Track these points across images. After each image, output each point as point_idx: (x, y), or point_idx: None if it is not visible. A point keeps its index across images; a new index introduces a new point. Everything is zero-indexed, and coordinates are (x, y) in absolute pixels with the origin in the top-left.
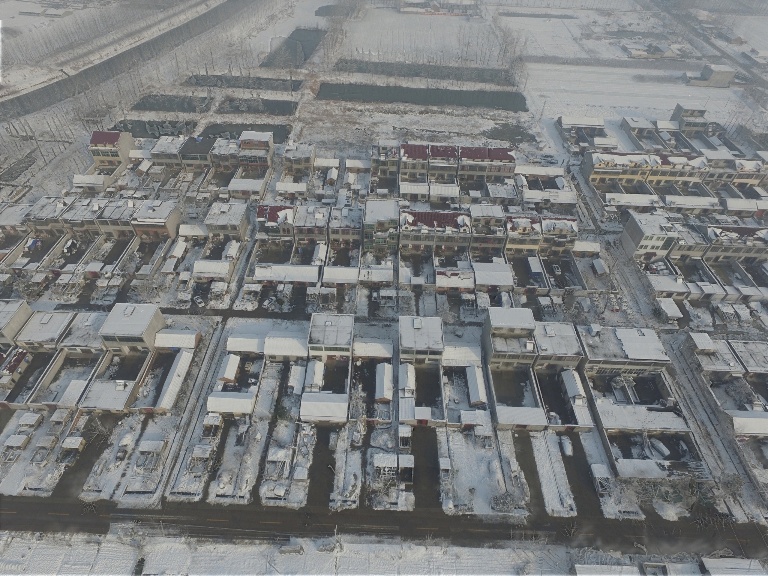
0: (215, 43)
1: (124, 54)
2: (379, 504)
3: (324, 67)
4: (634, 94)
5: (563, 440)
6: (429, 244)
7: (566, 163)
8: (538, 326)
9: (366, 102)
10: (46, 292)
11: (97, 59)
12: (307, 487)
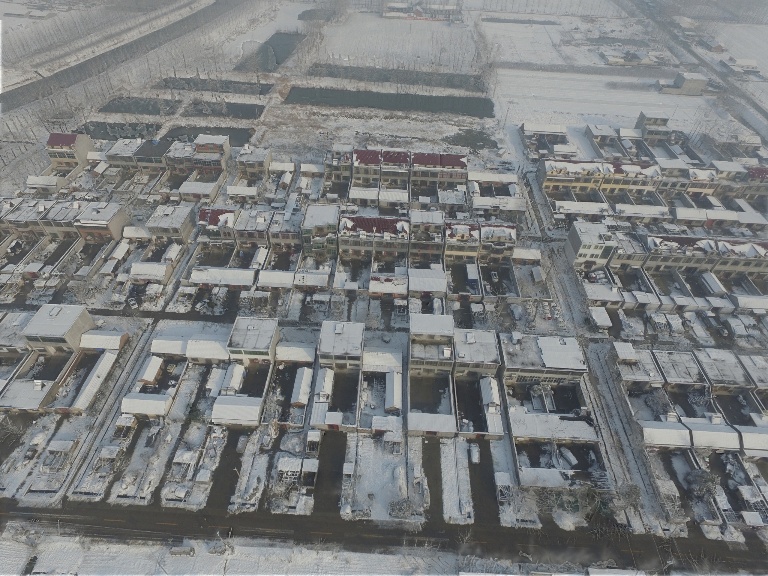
0: (192, 46)
1: (102, 56)
2: (278, 508)
3: (297, 71)
4: (604, 101)
5: (471, 447)
6: (368, 249)
7: (522, 170)
8: (460, 333)
9: (333, 106)
10: None
11: (73, 61)
12: (208, 489)
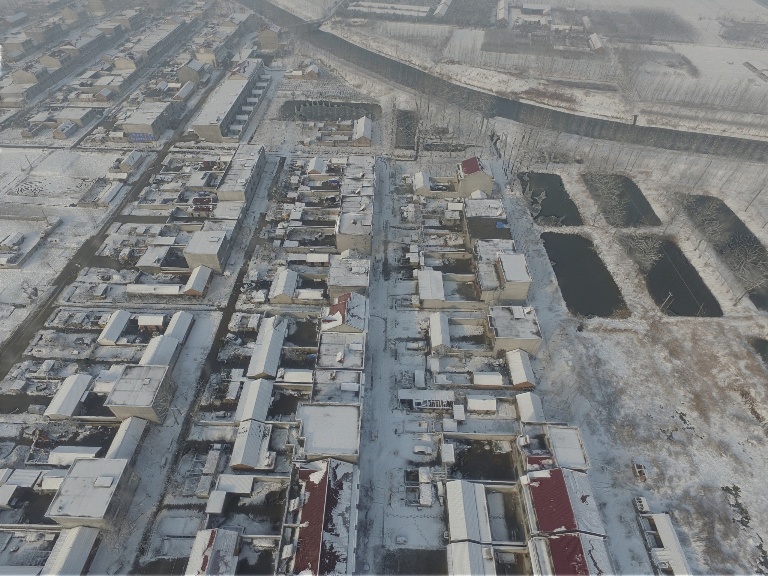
0: None
1: (732, 140)
2: None
3: None
4: None
5: None
6: None
7: None
8: None
9: None
10: (281, 204)
11: (688, 127)
12: None
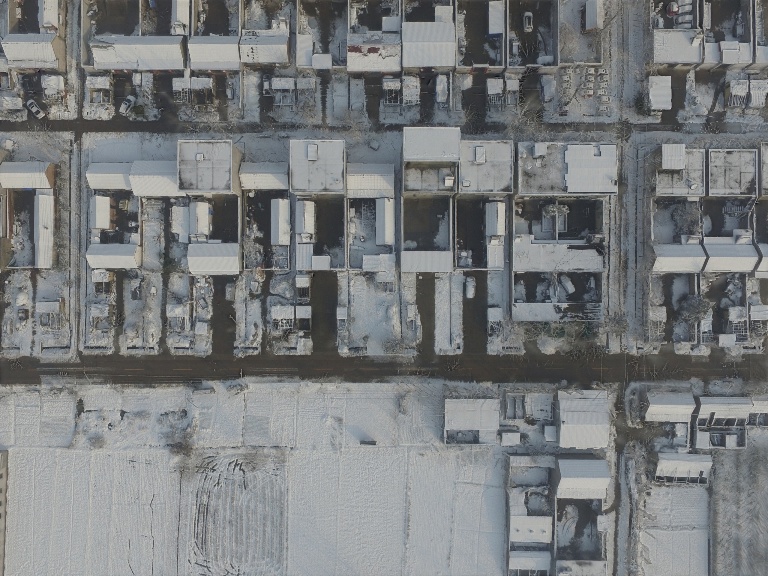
0: None
1: None
2: (279, 350)
3: None
4: None
5: (467, 283)
6: None
7: None
8: (467, 148)
9: None
10: None
11: None
12: None
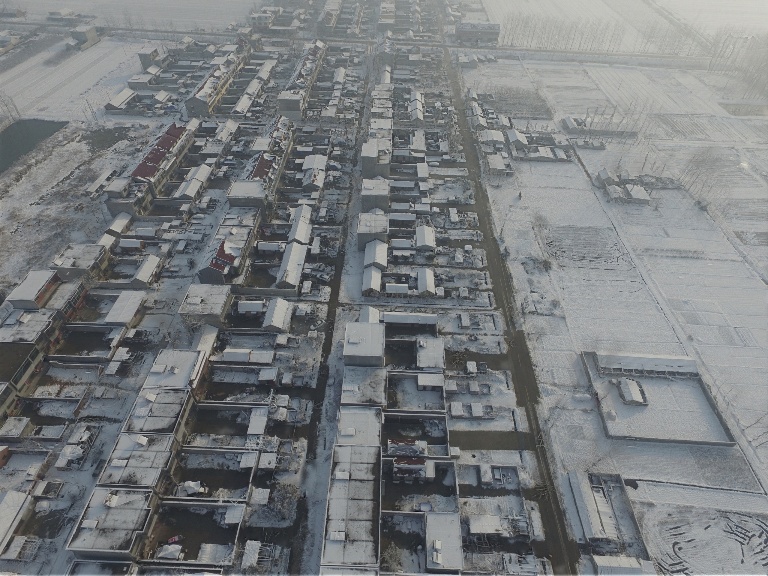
0: None
1: None
2: None
3: None
4: (79, 72)
5: (432, 164)
6: None
7: None
8: None
9: None
10: None
11: None
12: None
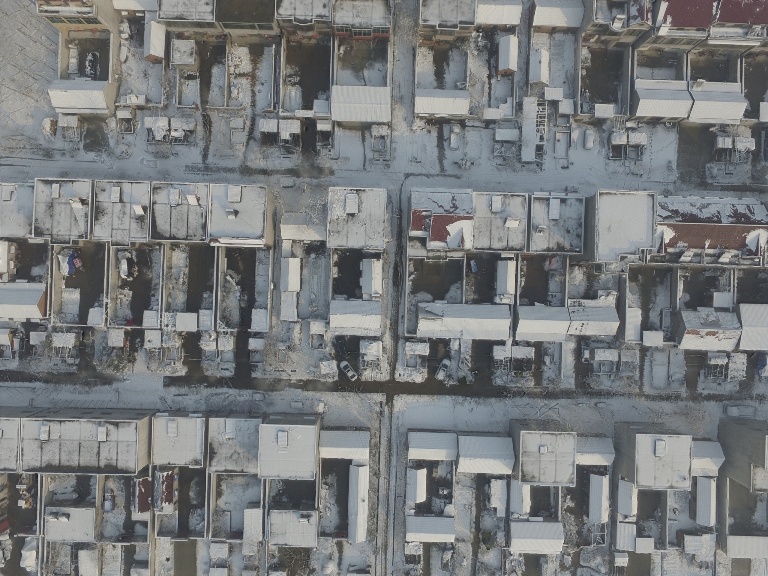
0: None
1: None
2: None
3: None
4: None
5: None
6: None
7: None
8: None
9: None
10: (137, 356)
11: None
12: None
